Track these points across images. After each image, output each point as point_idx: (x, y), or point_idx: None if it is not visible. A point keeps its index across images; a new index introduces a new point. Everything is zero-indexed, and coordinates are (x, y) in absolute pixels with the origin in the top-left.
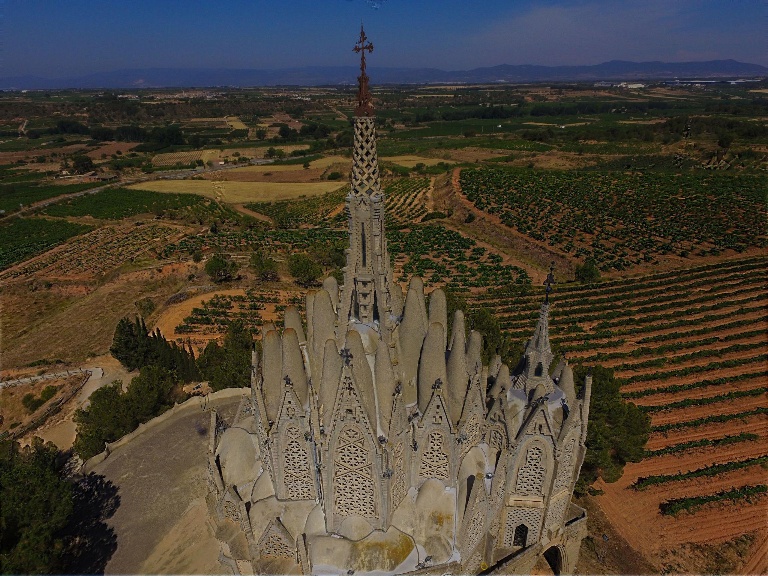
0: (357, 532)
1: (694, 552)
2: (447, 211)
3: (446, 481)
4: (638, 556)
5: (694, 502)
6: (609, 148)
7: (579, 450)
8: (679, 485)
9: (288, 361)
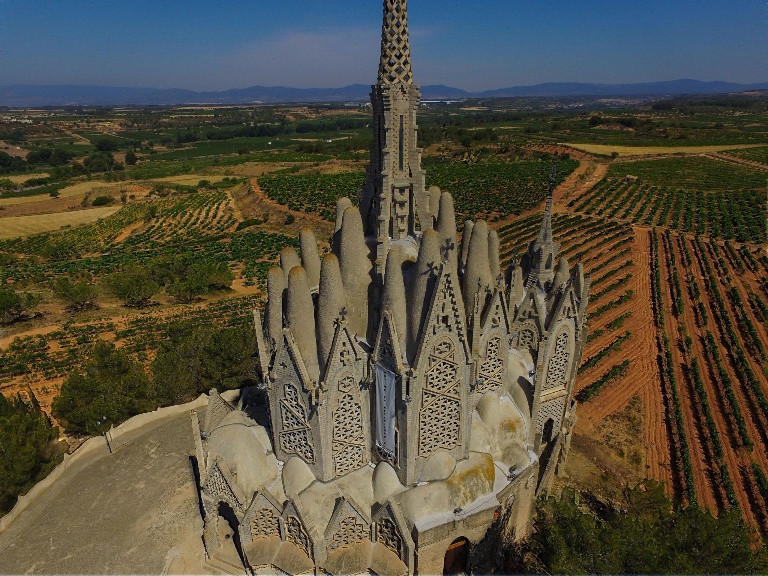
0: (447, 468)
1: (614, 421)
2: (261, 217)
3: (499, 391)
4: (585, 438)
5: (598, 385)
6: None
7: (582, 332)
8: (578, 379)
9: (335, 293)
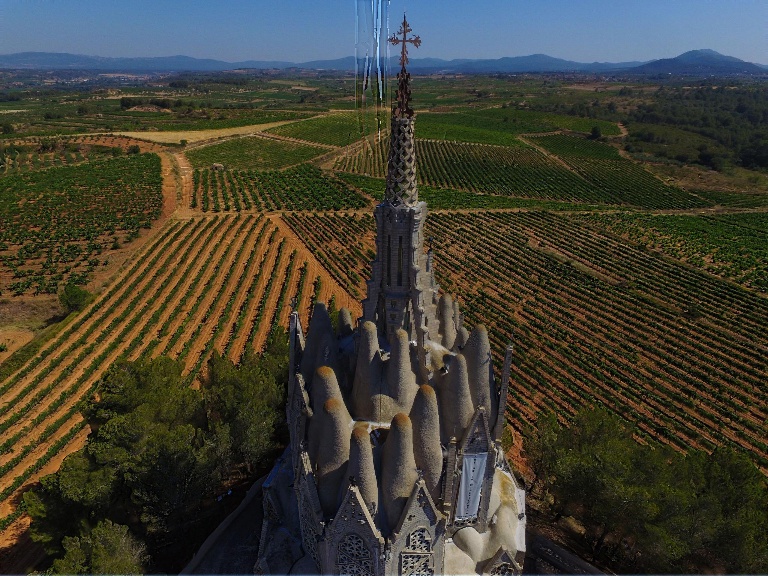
0: None
1: None
2: None
3: None
4: None
5: None
6: None
7: None
8: None
9: None
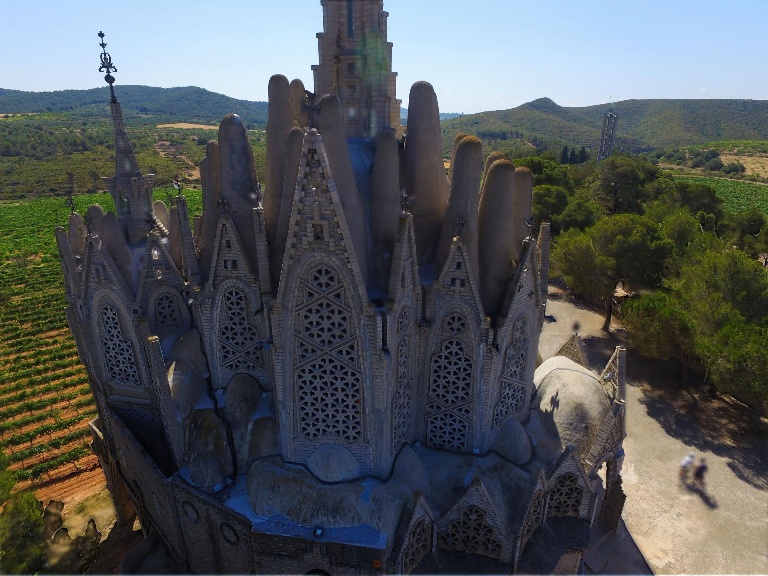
0: None
1: None
2: None
3: None
4: None
5: None
6: None
7: None
8: None
9: None
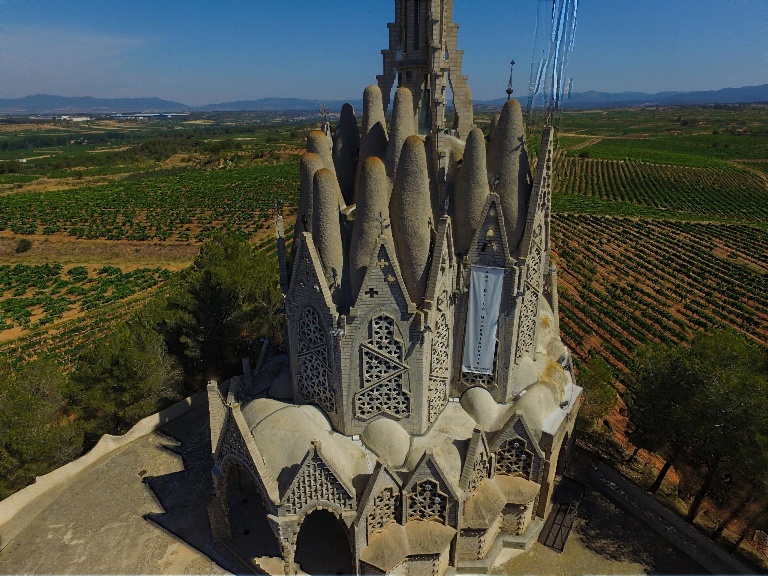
0: None
1: None
2: None
3: None
4: None
5: None
6: (133, 156)
7: None
8: None
9: (427, 184)
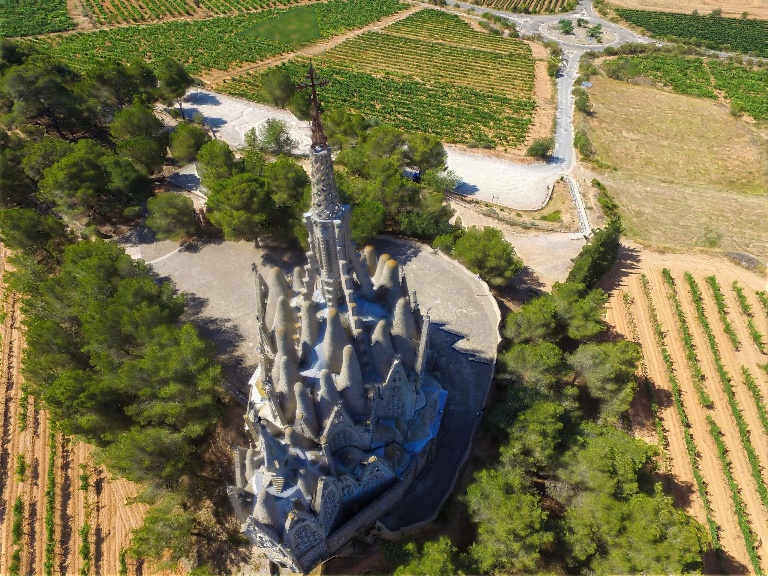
0: None
1: None
2: None
3: None
4: None
5: None
6: None
7: None
8: None
9: None
